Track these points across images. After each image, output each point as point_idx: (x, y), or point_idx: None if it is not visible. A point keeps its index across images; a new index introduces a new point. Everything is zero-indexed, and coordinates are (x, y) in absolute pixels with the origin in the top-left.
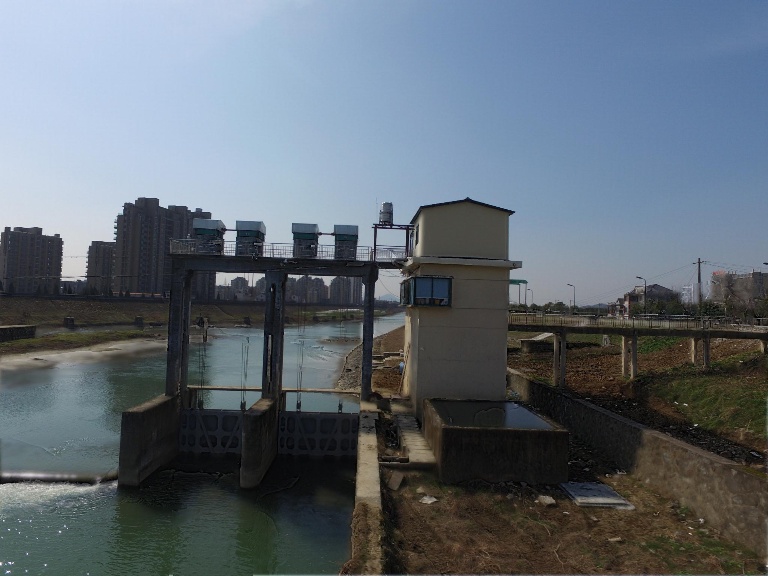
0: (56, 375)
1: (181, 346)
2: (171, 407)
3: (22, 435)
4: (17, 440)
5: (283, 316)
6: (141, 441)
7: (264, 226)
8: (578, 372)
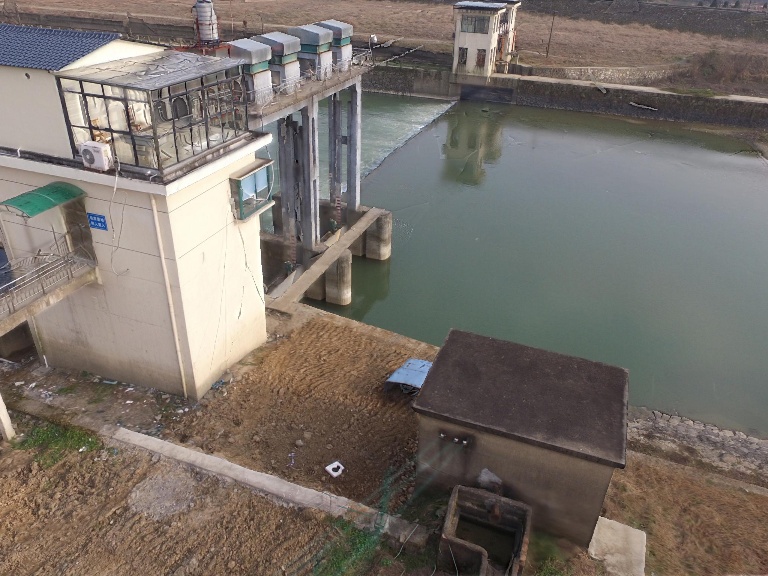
0: (719, 195)
1: (338, 162)
2: (322, 213)
3: (427, 206)
4: (411, 206)
5: (303, 159)
6: (275, 217)
7: (311, 33)
8: (6, 563)
